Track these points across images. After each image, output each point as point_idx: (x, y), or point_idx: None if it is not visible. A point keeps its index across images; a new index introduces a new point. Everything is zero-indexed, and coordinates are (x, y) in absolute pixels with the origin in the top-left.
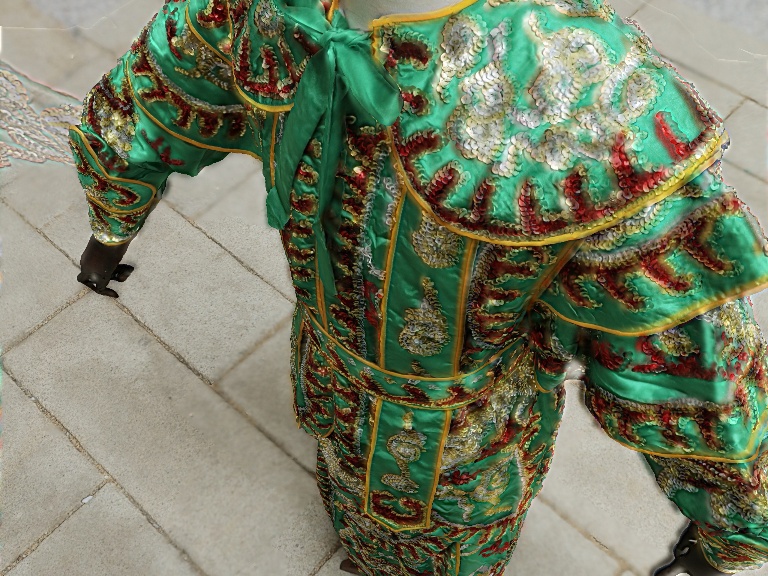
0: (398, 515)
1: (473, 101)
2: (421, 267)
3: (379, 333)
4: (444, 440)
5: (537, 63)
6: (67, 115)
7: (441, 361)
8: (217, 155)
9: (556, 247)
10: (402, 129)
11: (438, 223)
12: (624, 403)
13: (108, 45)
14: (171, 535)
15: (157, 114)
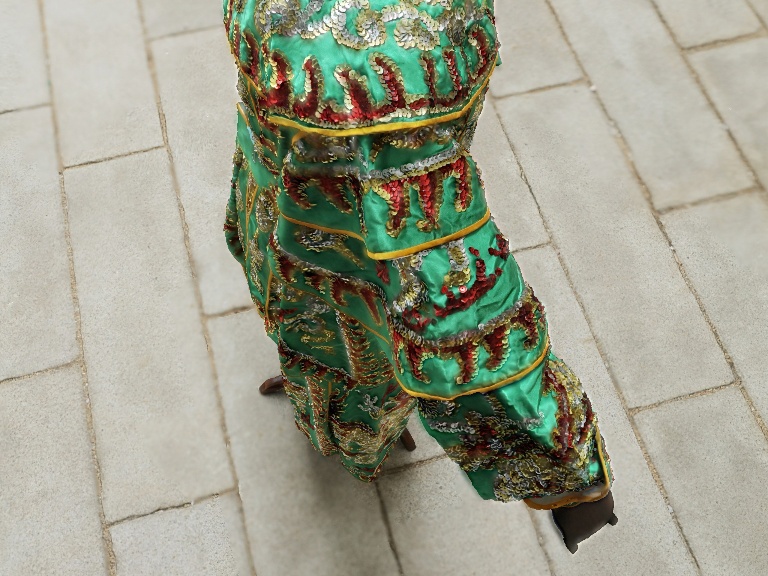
0: None
1: None
2: None
3: None
4: None
5: None
6: None
7: None
8: None
9: None
10: None
11: None
12: None
13: None
14: (547, 567)
15: None
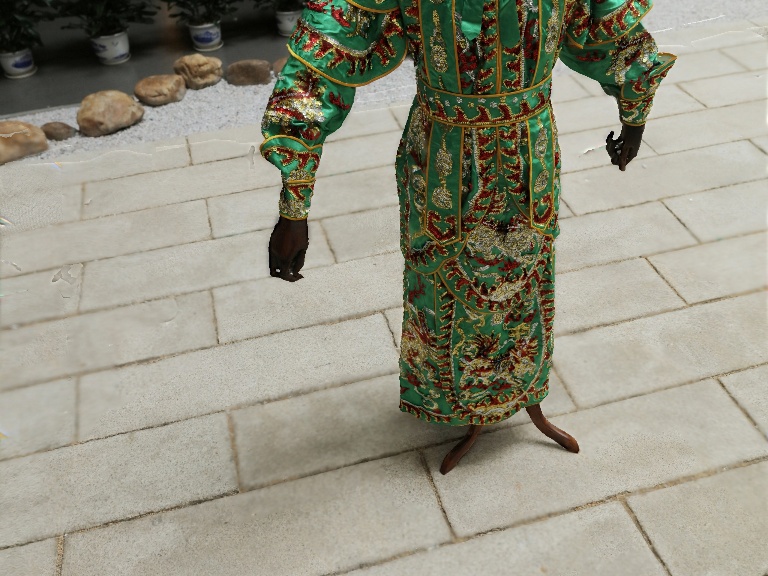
0: (542, 217)
1: None
2: None
3: (535, 53)
4: None
5: None
6: None
7: None
8: None
9: None
10: None
11: None
12: (616, 12)
13: None
14: (342, 568)
15: (339, 74)
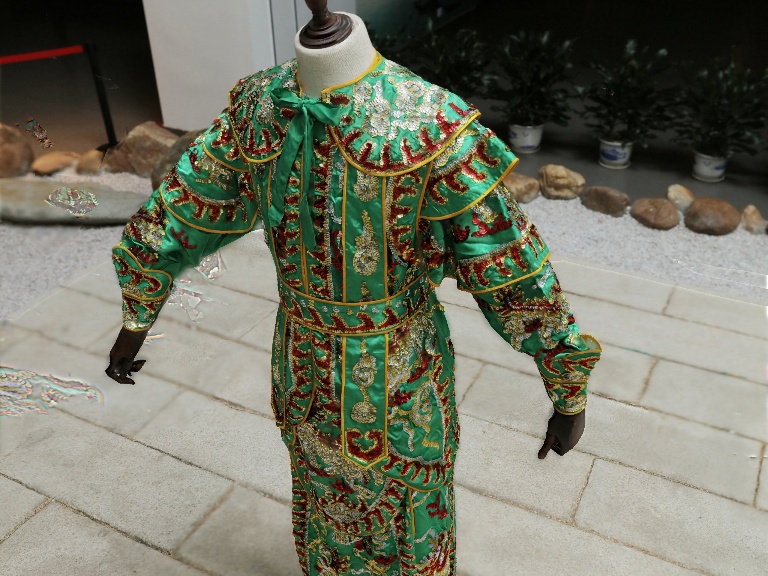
0: (365, 452)
1: (371, 113)
2: (360, 204)
3: (341, 267)
4: (386, 358)
5: (395, 93)
6: (5, 381)
7: (377, 282)
8: (212, 248)
9: (421, 172)
10: (341, 134)
11: (365, 174)
12: (473, 260)
13: (34, 327)
14: None
15: (182, 213)
